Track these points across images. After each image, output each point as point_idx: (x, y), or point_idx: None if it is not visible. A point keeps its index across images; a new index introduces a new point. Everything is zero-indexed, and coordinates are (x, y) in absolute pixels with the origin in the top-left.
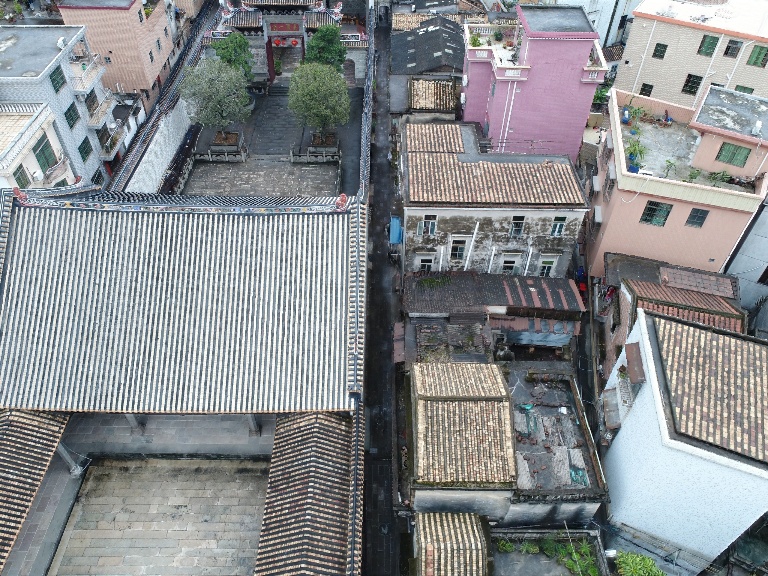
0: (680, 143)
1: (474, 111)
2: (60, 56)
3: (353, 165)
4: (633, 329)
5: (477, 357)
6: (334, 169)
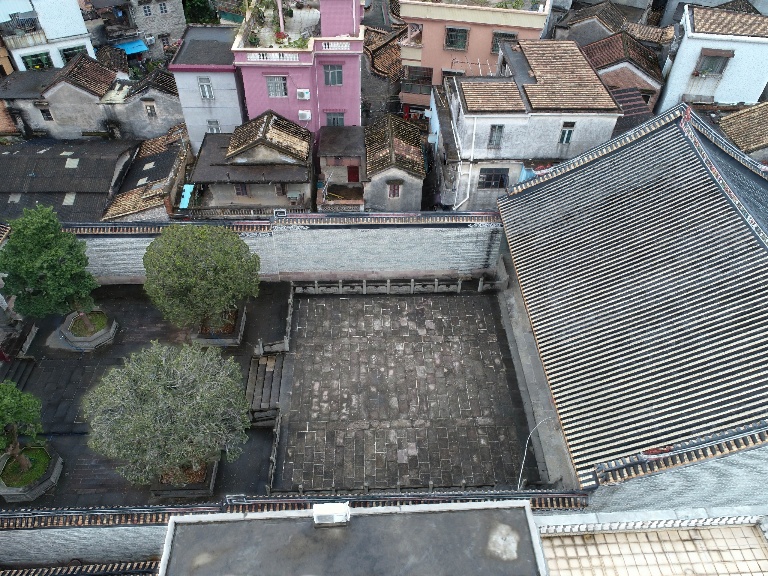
0: (466, 1)
1: (313, 120)
2: (387, 508)
3: (281, 293)
4: (686, 51)
5: (715, 128)
6: (309, 301)
